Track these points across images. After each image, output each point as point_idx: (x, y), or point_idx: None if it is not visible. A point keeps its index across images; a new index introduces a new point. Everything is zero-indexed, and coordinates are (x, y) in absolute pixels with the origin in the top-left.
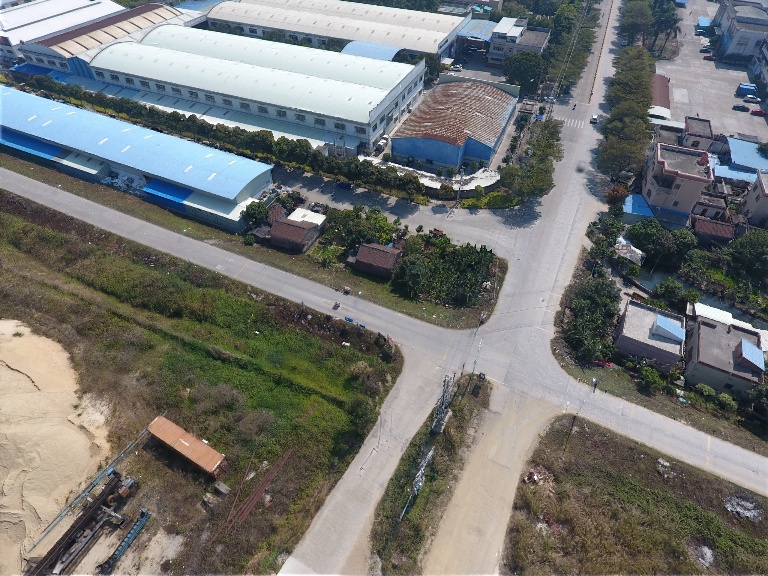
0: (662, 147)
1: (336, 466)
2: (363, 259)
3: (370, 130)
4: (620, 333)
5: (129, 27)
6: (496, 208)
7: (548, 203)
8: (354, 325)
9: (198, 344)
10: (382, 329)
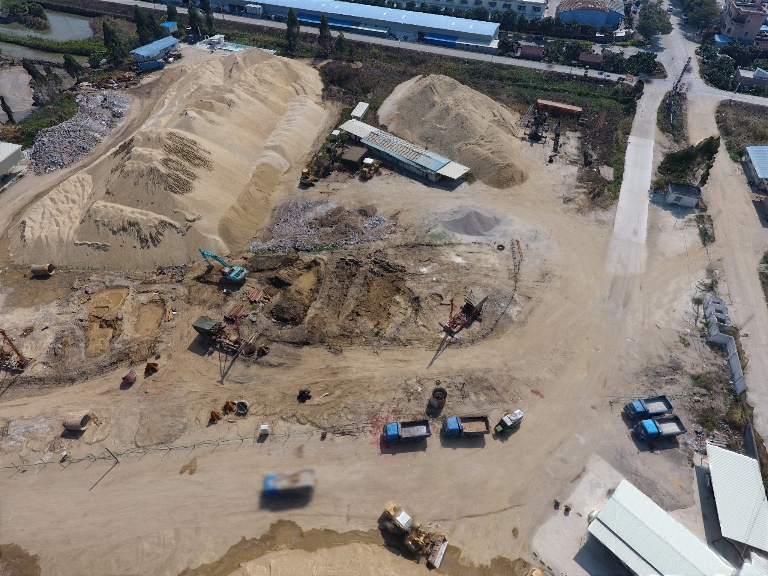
0: (735, 4)
1: (631, 113)
2: (584, 59)
3: None
4: (738, 78)
5: None
6: (637, 46)
7: (665, 44)
8: (601, 78)
9: None
10: (616, 79)
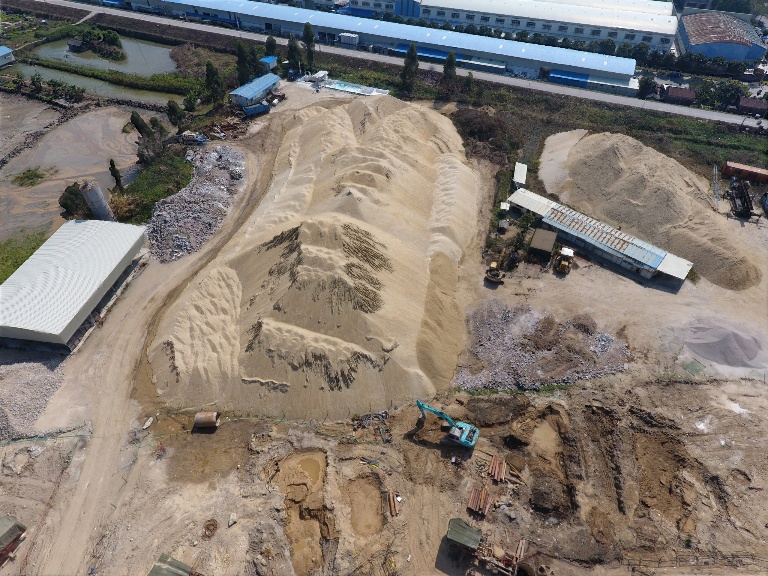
0: None
1: None
2: (746, 105)
3: None
4: None
5: None
6: None
7: None
8: None
9: (700, 139)
10: None
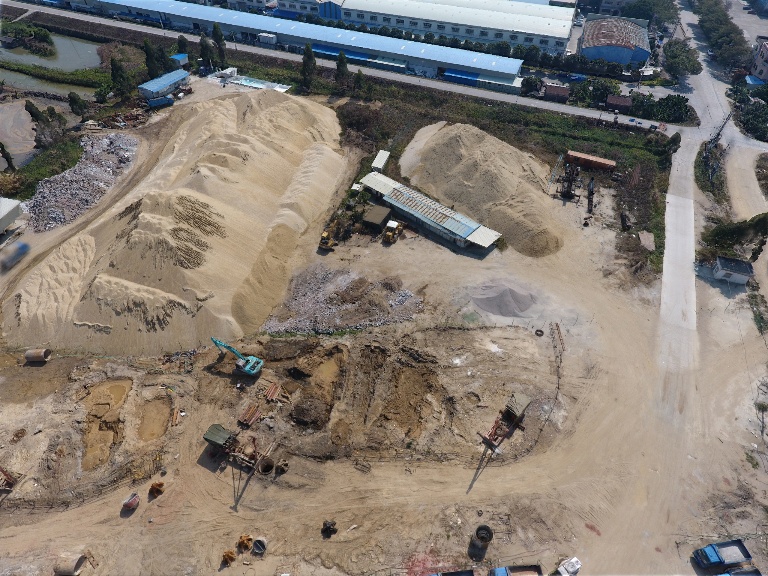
0: None
1: (667, 168)
2: (612, 102)
3: None
4: None
5: None
6: (665, 85)
7: (694, 84)
8: None
9: None
10: (648, 127)
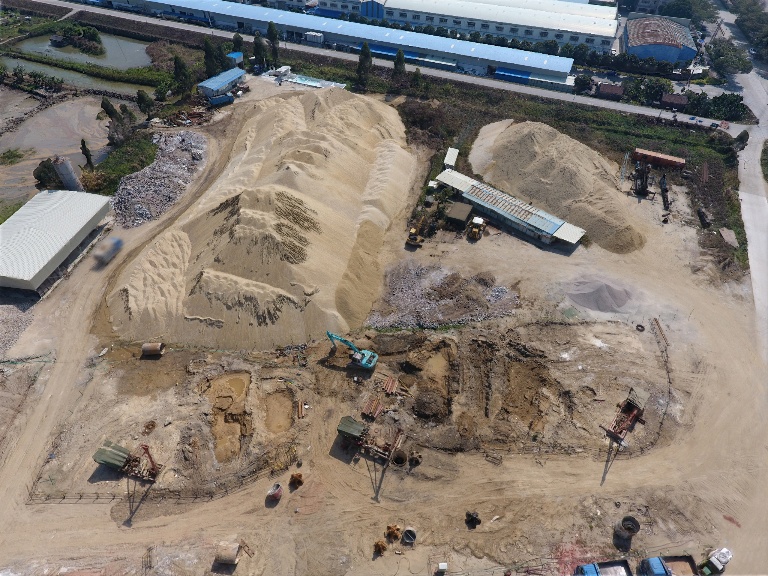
0: None
1: None
2: (667, 100)
3: (613, 42)
4: None
5: None
6: (714, 84)
7: (742, 82)
8: (692, 123)
9: None
10: (708, 125)
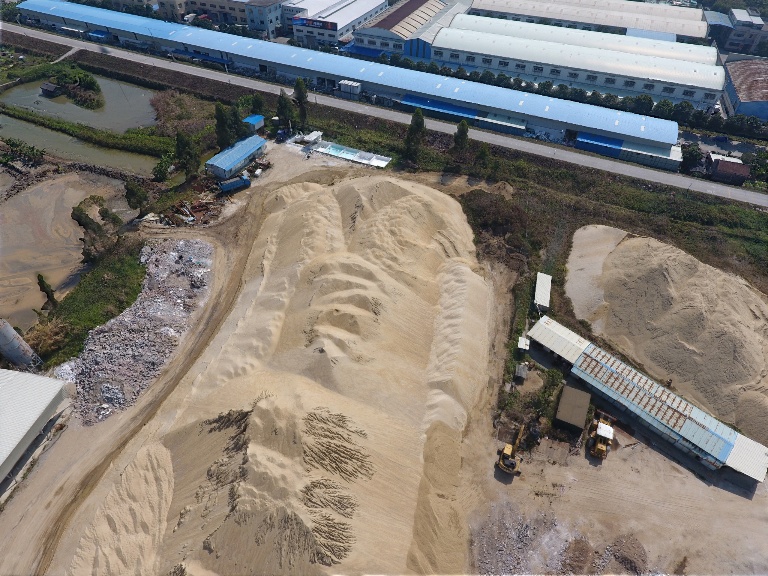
0: None
1: None
2: None
3: None
4: None
5: (424, 15)
6: None
7: None
8: None
9: None
10: None
